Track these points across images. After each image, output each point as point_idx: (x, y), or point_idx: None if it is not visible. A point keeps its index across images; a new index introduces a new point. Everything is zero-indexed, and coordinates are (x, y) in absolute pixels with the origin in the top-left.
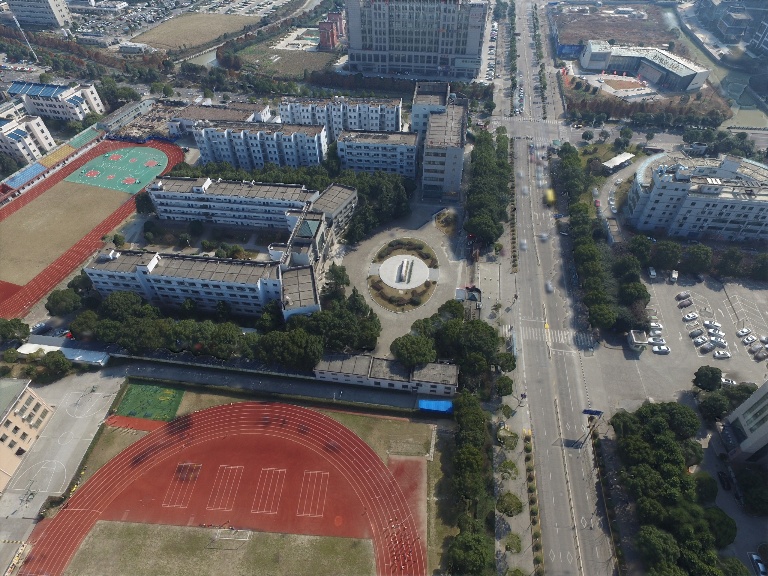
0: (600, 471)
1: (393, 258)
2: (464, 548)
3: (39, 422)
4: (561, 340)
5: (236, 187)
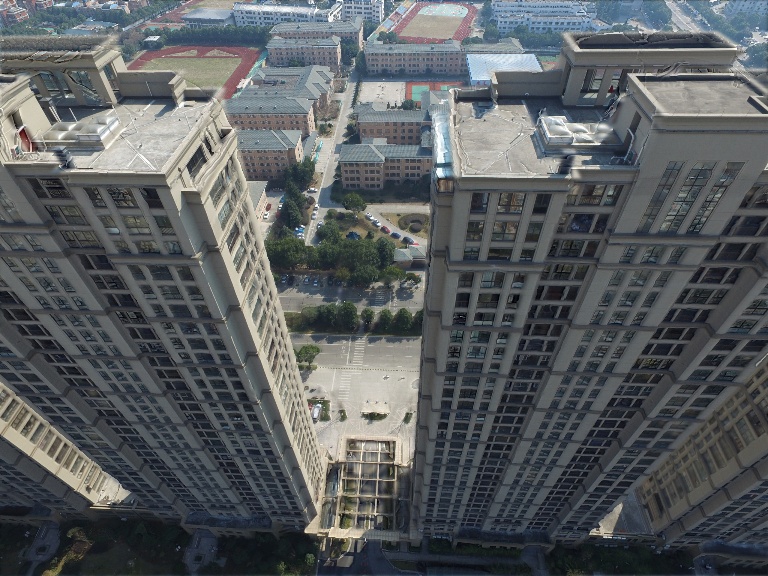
0: None
1: None
2: None
3: None
4: None
5: (537, 1)
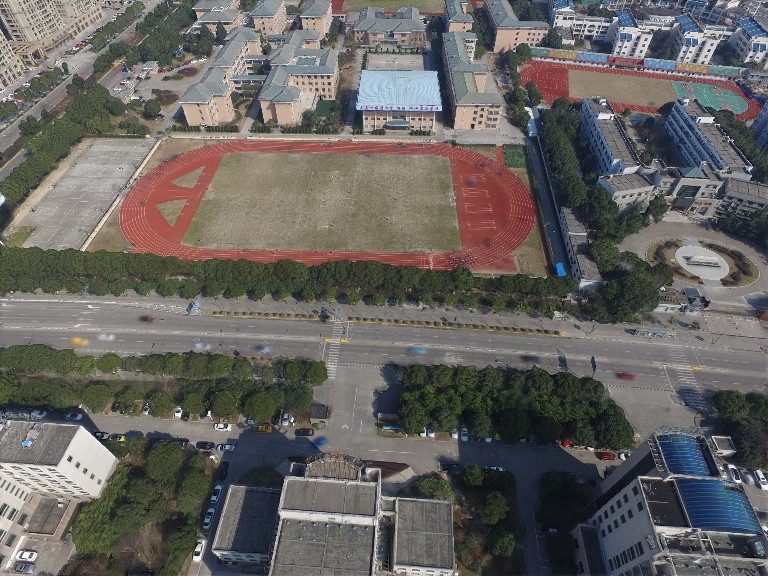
0: None
1: (715, 254)
2: None
3: (489, 126)
4: (682, 378)
5: (717, 135)
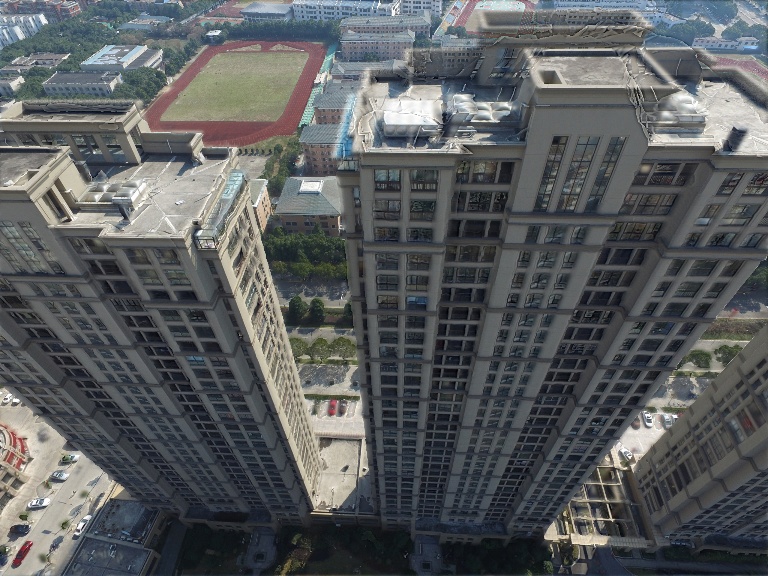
0: None
1: None
2: None
3: None
4: None
5: None
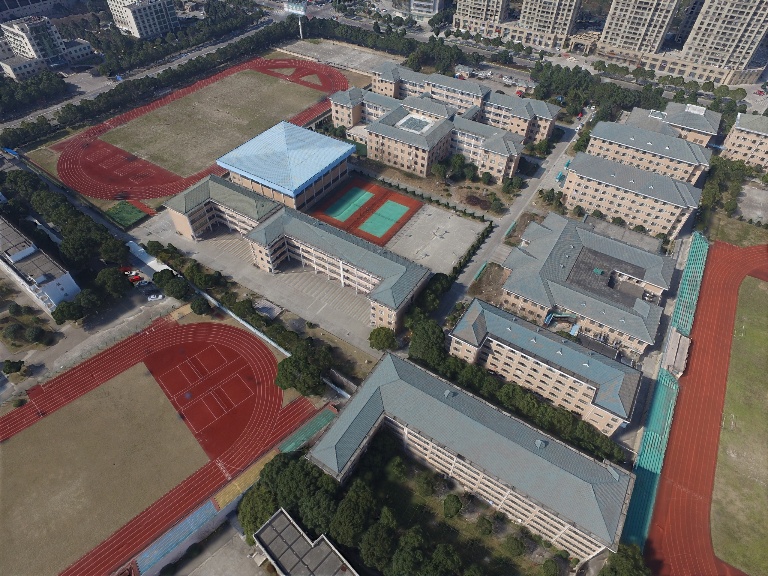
0: (0, 123)
1: None
2: (70, 109)
3: None
4: None
5: None
